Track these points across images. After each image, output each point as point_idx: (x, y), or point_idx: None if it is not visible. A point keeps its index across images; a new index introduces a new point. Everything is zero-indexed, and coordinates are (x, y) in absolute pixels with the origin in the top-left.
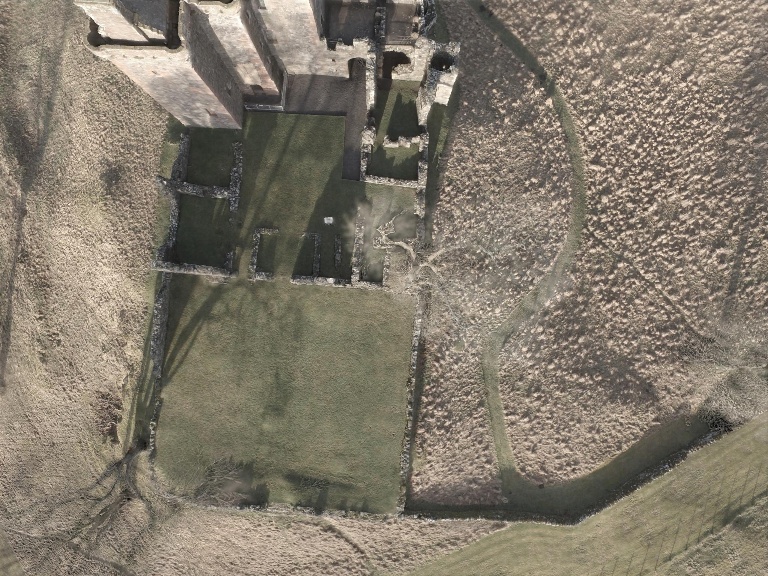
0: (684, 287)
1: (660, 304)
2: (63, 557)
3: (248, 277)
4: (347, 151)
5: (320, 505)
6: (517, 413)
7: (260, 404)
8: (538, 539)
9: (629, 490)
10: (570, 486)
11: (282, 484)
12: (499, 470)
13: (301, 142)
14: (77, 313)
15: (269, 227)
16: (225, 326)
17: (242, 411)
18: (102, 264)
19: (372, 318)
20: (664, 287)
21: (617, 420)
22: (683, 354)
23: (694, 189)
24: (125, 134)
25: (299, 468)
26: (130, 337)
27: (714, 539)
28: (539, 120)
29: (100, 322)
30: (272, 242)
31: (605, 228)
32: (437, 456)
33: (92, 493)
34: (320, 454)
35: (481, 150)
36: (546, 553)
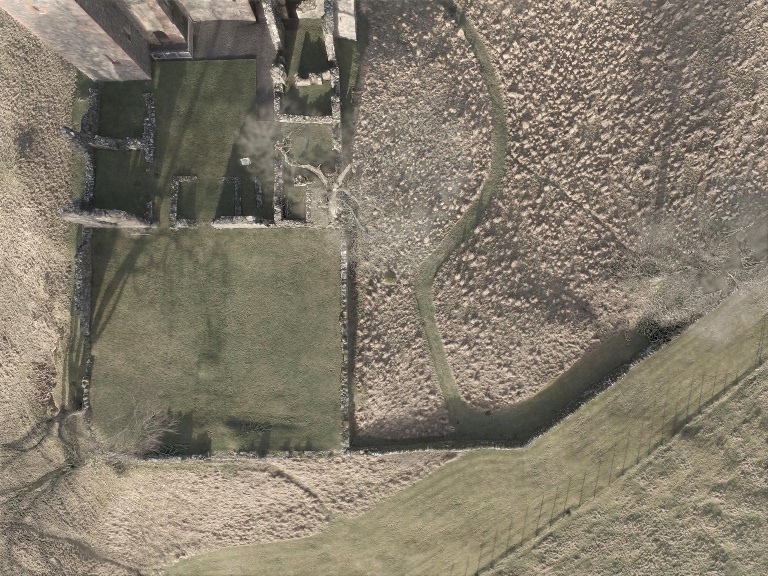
0: (612, 205)
1: (589, 223)
2: (18, 540)
3: (170, 226)
4: (260, 93)
5: (263, 448)
6: (456, 341)
7: (194, 353)
8: (490, 466)
9: (574, 407)
10: (516, 410)
11: (223, 431)
12: (444, 400)
13: (213, 88)
14: (6, 285)
15: (187, 174)
16: (151, 278)
17: (176, 362)
18: (23, 229)
19: (299, 256)
20: (592, 206)
21: (556, 340)
22: (616, 270)
23: (613, 109)
24: (36, 97)
25: (239, 414)
26: (56, 298)
27: (664, 450)
28: (453, 52)
29: (28, 290)
30: (192, 189)
31: (528, 153)
32: (378, 389)
33: (39, 469)
34: (259, 398)
35: (395, 83)
36: (499, 479)
